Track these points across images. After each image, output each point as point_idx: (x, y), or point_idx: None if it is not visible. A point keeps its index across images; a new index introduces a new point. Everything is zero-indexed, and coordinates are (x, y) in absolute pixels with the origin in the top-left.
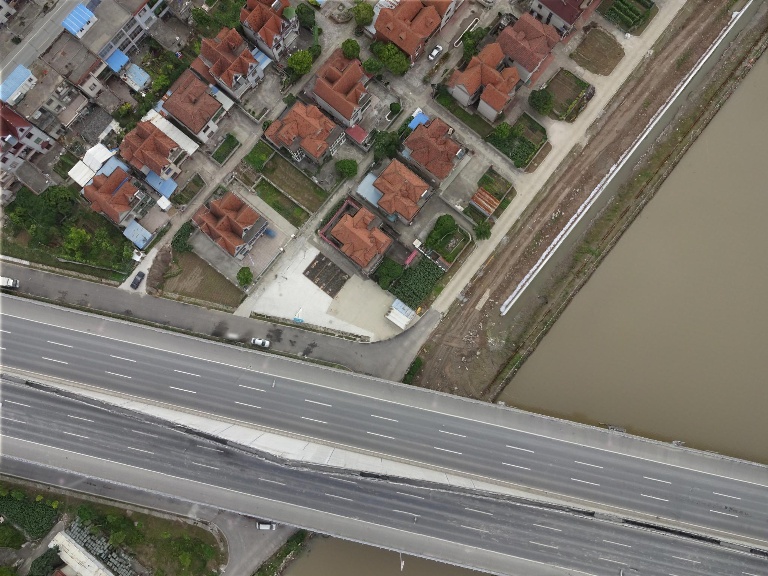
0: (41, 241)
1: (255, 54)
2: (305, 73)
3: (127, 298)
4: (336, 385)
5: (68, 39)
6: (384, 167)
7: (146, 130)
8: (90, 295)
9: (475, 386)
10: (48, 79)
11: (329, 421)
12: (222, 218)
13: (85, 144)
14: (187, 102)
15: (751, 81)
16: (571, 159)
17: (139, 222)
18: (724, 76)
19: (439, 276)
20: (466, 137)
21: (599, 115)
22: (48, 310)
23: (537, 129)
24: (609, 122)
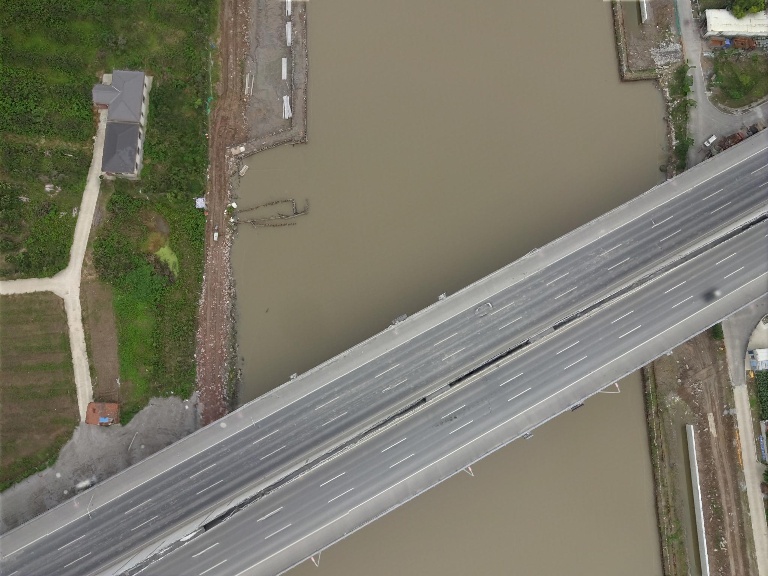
0: None
1: None
2: None
3: None
4: None
5: None
6: None
7: None
8: None
9: None
10: None
11: (766, 239)
12: None
13: None
14: None
15: None
16: None
17: None
18: None
19: (765, 413)
20: None
21: None
22: None
23: None
24: None
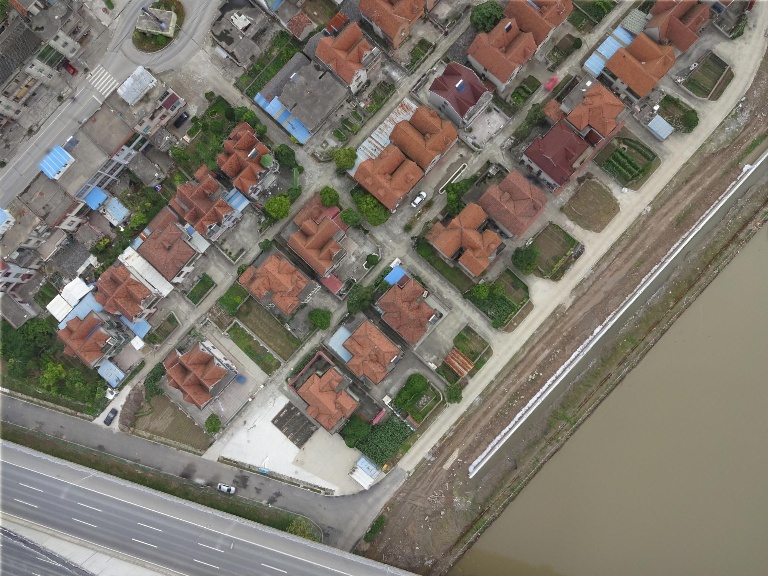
0: (19, 374)
1: (233, 195)
2: (283, 217)
3: (100, 433)
4: (292, 552)
5: (46, 179)
6: (357, 321)
7: (119, 278)
8: (65, 427)
9: (437, 547)
10: (26, 220)
11: None
12: (189, 374)
13: (65, 275)
14: (161, 248)
15: (756, 245)
16: (553, 320)
17: (114, 359)
18: (727, 237)
19: (407, 435)
20: (445, 291)
21: (586, 275)
22: (21, 452)
23: (519, 286)
24: (597, 282)
